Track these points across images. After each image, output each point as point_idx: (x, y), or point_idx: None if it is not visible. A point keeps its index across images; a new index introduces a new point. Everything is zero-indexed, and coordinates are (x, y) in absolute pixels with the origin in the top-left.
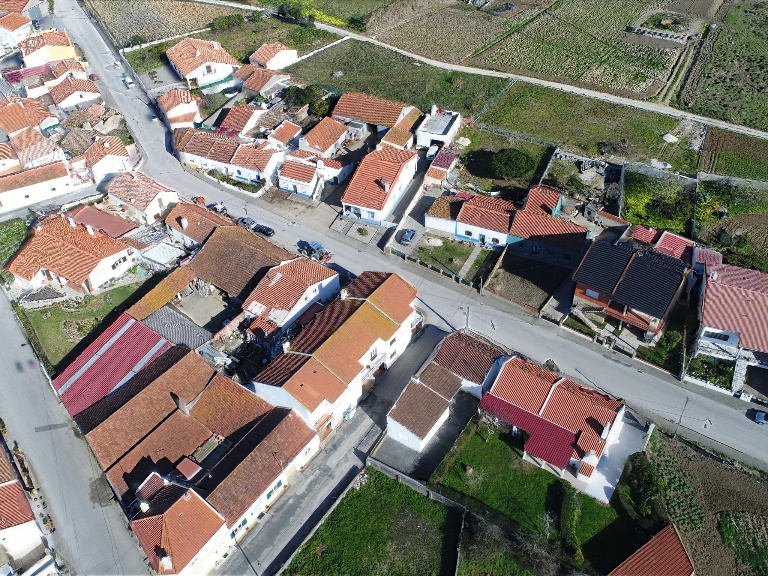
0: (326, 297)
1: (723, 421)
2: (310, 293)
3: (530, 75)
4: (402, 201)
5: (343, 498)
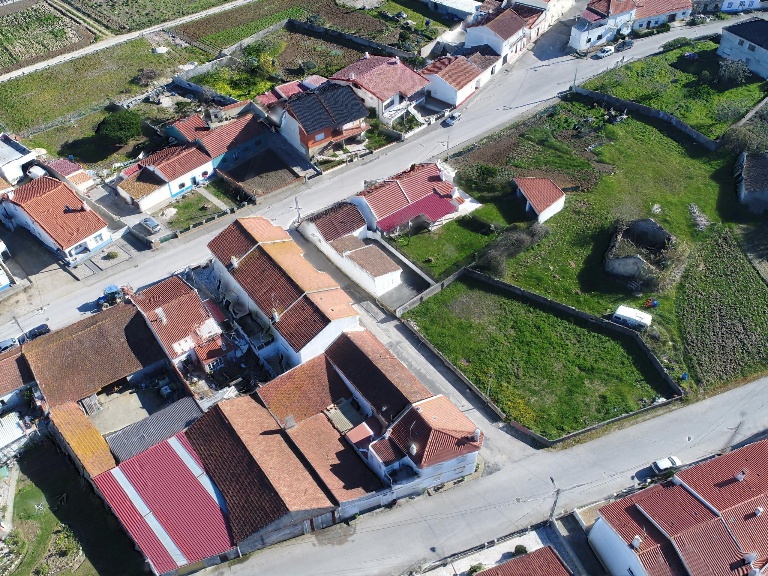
0: None
1: (444, 137)
2: None
3: None
4: None
5: None
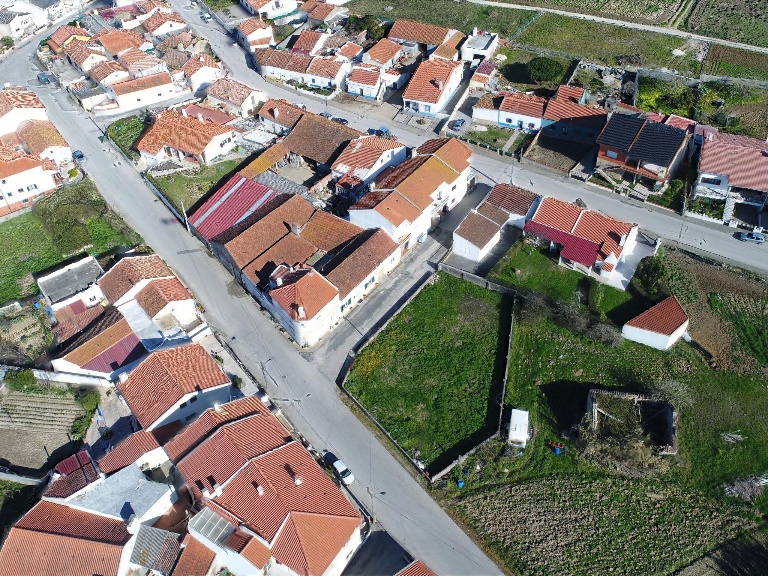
0: (396, 164)
1: (715, 240)
2: (385, 157)
3: (556, 8)
4: (452, 100)
5: (422, 289)
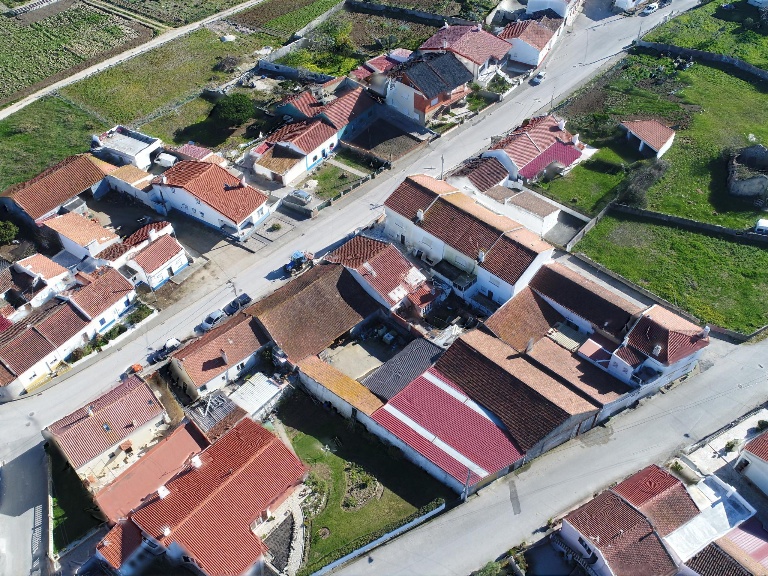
0: None
1: (537, 95)
2: None
3: (47, 84)
4: None
5: None
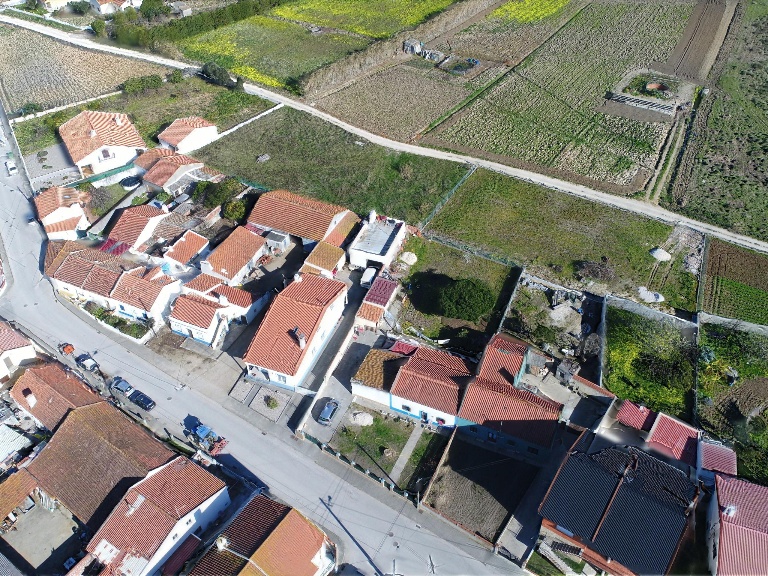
0: (209, 520)
1: None
2: (181, 527)
3: (493, 159)
4: (326, 351)
5: None
